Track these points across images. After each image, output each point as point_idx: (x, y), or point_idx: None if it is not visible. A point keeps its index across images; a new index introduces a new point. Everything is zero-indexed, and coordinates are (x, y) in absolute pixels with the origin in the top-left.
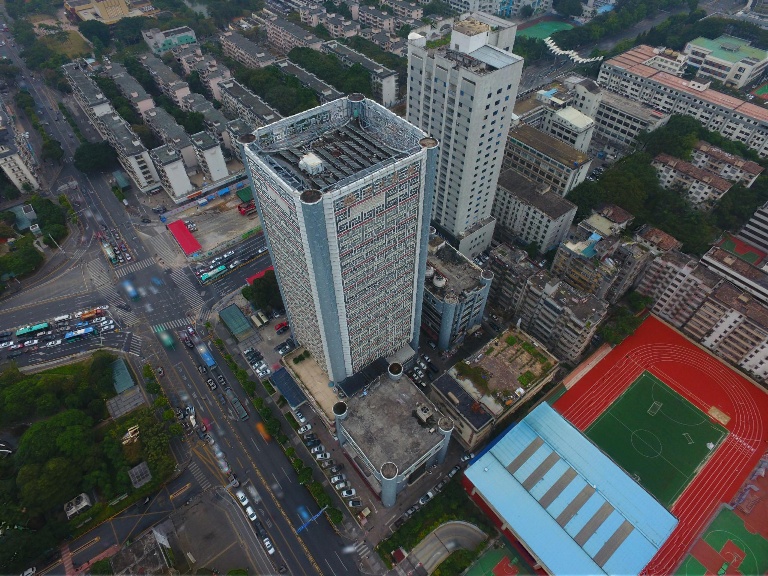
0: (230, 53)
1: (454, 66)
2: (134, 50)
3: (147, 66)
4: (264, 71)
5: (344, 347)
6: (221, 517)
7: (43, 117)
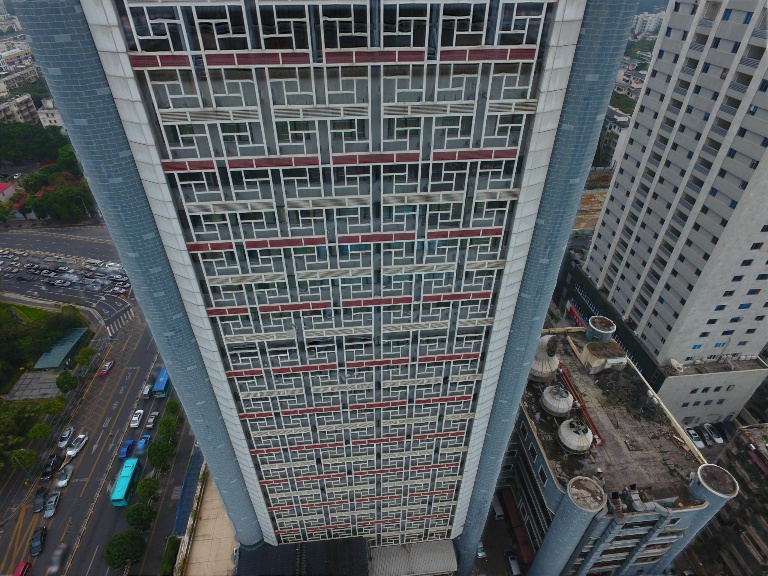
0: None
1: None
2: None
3: None
4: None
5: (245, 474)
6: None
7: None
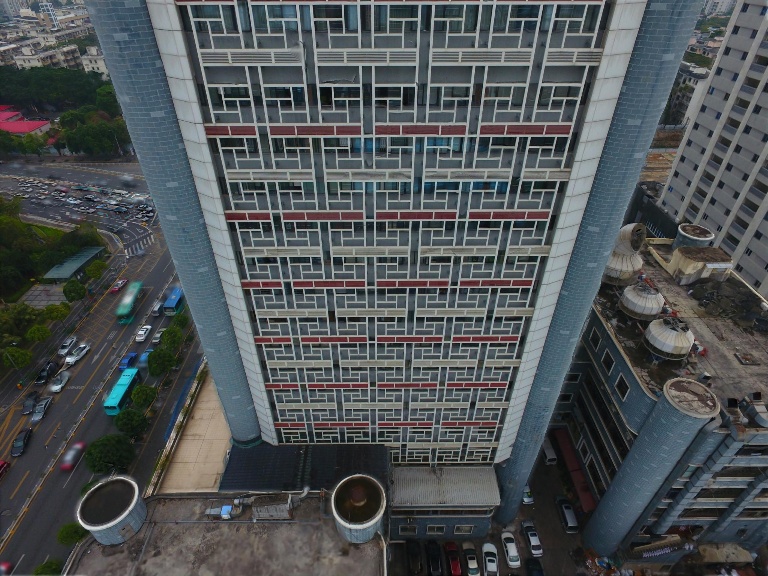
0: None
1: None
2: None
3: None
4: None
5: (237, 326)
6: None
7: None
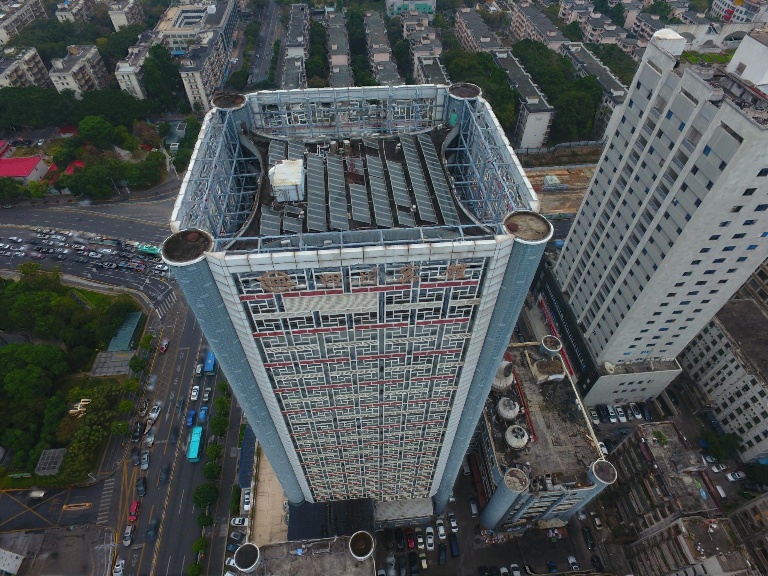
0: (459, 32)
1: (715, 99)
2: (371, 8)
3: (366, 23)
4: (474, 56)
5: (296, 472)
6: (84, 574)
7: (259, 49)
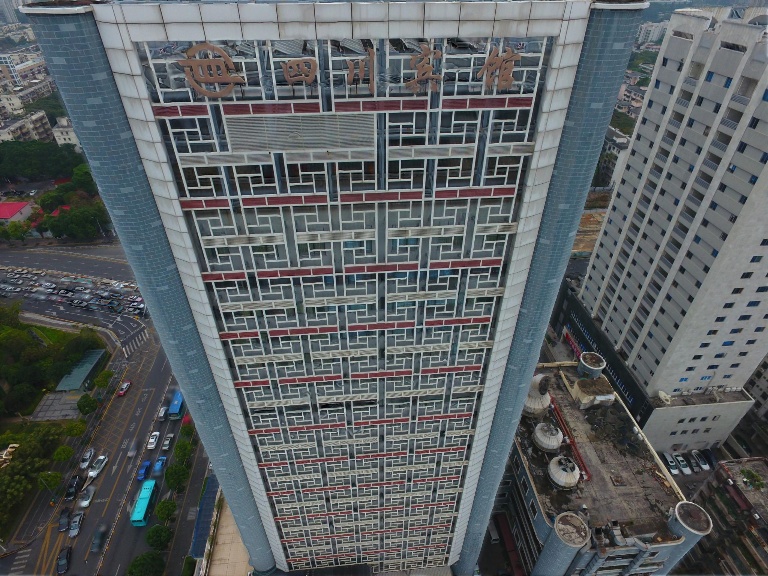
0: None
1: None
2: None
3: None
4: None
5: (261, 511)
6: None
7: None
